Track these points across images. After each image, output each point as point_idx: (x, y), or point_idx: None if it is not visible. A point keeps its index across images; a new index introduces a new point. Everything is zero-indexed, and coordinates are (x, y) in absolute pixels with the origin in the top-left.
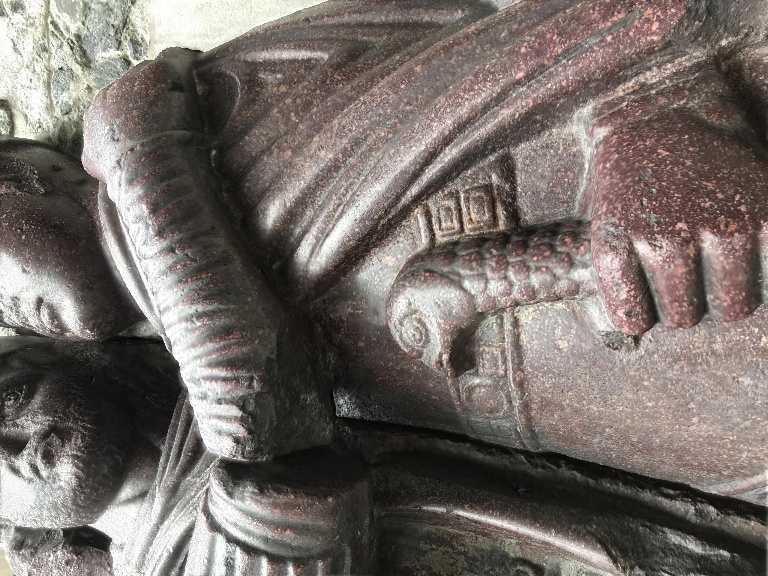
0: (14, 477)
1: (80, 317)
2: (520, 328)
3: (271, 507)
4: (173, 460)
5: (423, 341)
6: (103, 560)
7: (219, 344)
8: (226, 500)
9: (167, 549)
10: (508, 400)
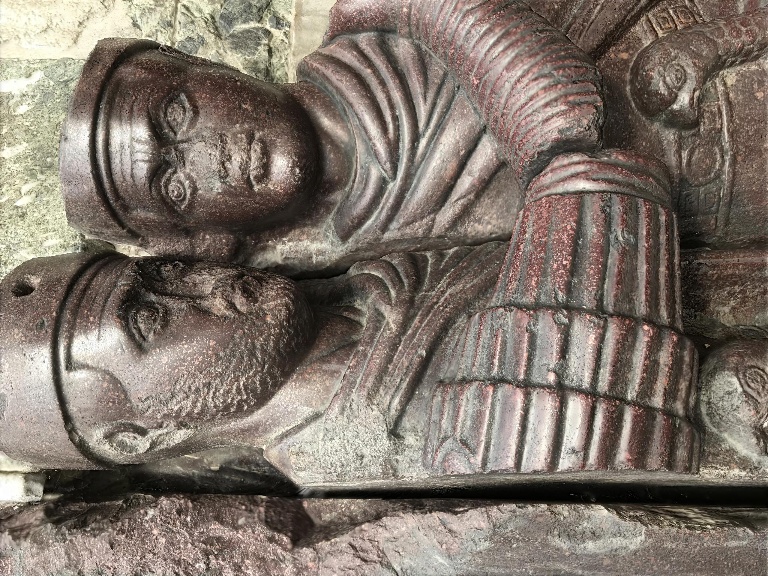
0: (202, 317)
1: (296, 152)
2: (728, 89)
3: (635, 157)
4: (398, 284)
5: (682, 81)
6: (231, 501)
7: (564, 47)
8: (590, 161)
9: (418, 354)
10: (721, 155)
